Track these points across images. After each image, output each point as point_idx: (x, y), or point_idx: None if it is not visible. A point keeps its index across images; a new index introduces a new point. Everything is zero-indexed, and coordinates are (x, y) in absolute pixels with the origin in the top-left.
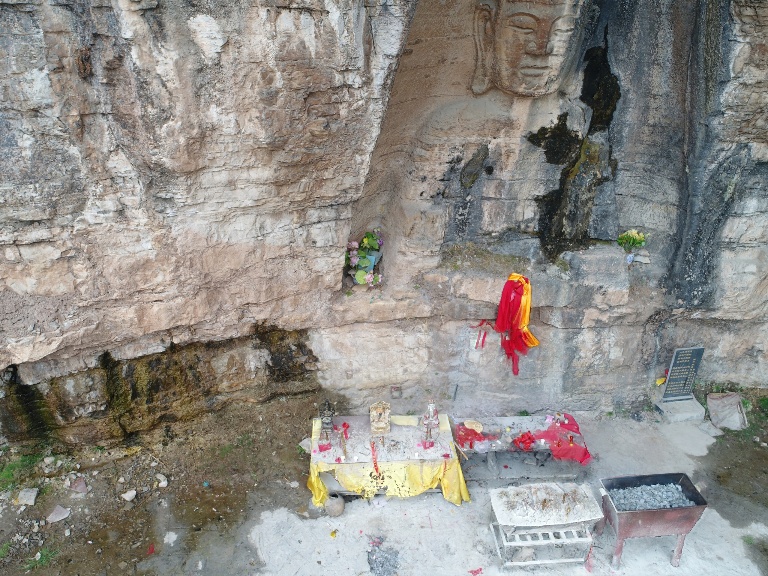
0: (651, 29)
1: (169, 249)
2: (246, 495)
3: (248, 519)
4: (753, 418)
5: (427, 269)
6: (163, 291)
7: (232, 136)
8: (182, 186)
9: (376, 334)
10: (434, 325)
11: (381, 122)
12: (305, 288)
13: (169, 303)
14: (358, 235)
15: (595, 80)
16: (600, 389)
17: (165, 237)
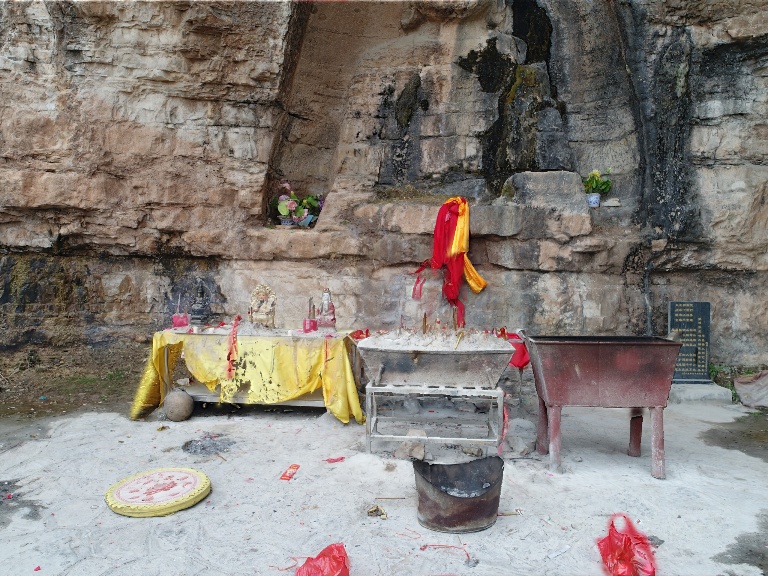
0: None
1: (72, 114)
2: (81, 405)
3: None
4: None
5: (357, 202)
6: (58, 162)
7: None
8: (91, 37)
9: (296, 274)
10: (364, 269)
11: (292, 3)
12: (216, 199)
13: (61, 175)
14: (297, 192)
15: (525, 17)
16: None
17: (70, 99)
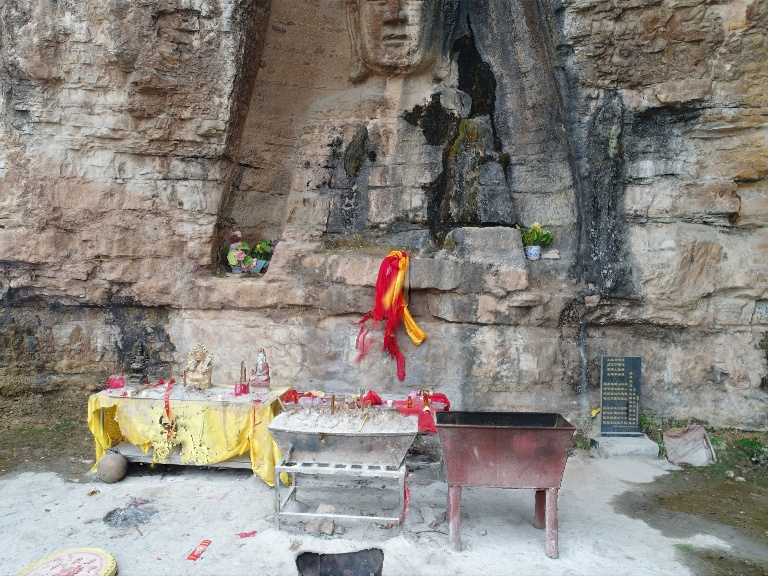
0: (505, 8)
1: (21, 171)
2: (22, 462)
3: (2, 475)
4: (726, 454)
5: (304, 252)
6: (7, 217)
7: (84, 45)
8: (38, 98)
9: (243, 323)
10: (310, 319)
11: (237, 63)
12: (165, 251)
13: (10, 230)
14: (250, 237)
15: (470, 71)
16: None
17: (19, 157)
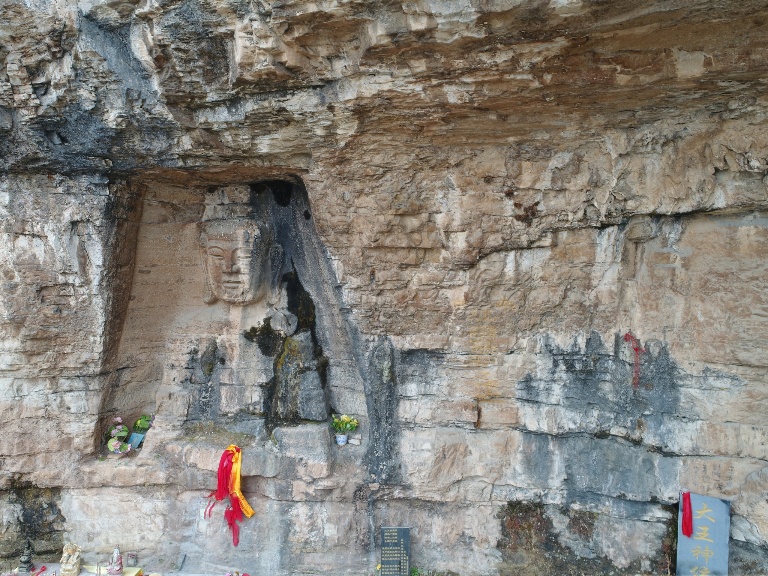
0: (315, 259)
1: None
2: None
3: None
4: None
5: (167, 440)
6: None
7: None
8: None
9: (119, 498)
10: (171, 493)
11: (106, 312)
12: (55, 447)
13: None
14: (132, 415)
15: (296, 296)
16: (319, 569)
17: None
